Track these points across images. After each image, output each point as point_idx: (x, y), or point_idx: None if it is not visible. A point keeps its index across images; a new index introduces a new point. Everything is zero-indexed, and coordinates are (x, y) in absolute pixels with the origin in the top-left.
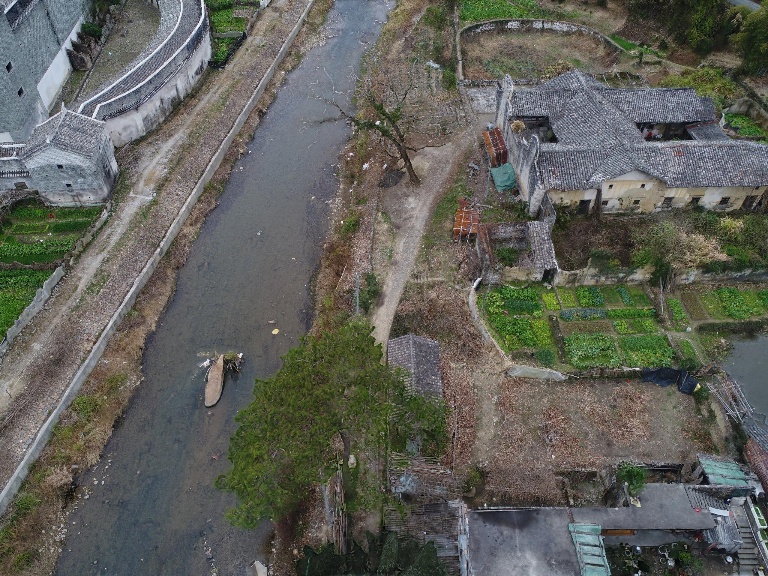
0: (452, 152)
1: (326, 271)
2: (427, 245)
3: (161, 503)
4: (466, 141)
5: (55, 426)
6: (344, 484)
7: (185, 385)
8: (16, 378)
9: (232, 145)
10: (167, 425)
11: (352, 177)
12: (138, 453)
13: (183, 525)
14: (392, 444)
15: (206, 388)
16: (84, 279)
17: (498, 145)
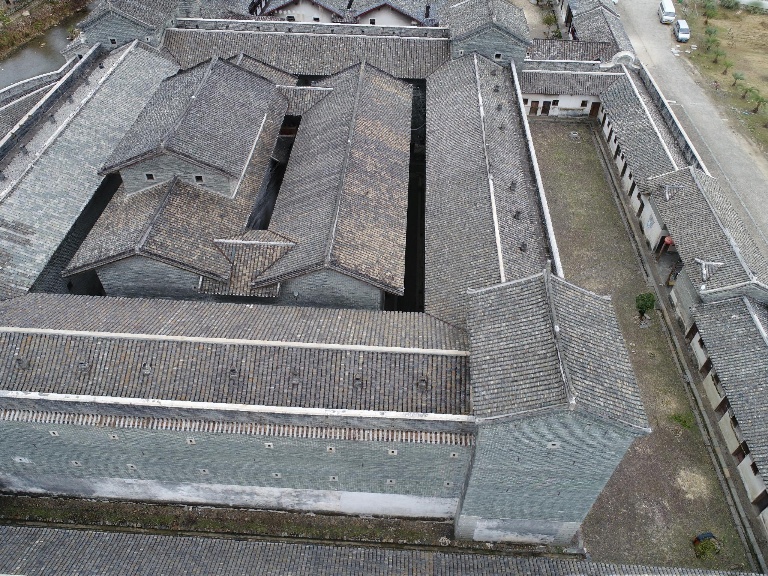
0: None
1: None
2: None
3: None
4: None
5: None
6: None
7: None
8: None
9: None
10: None
11: None
12: None
13: None
14: None
15: None
16: None
17: None
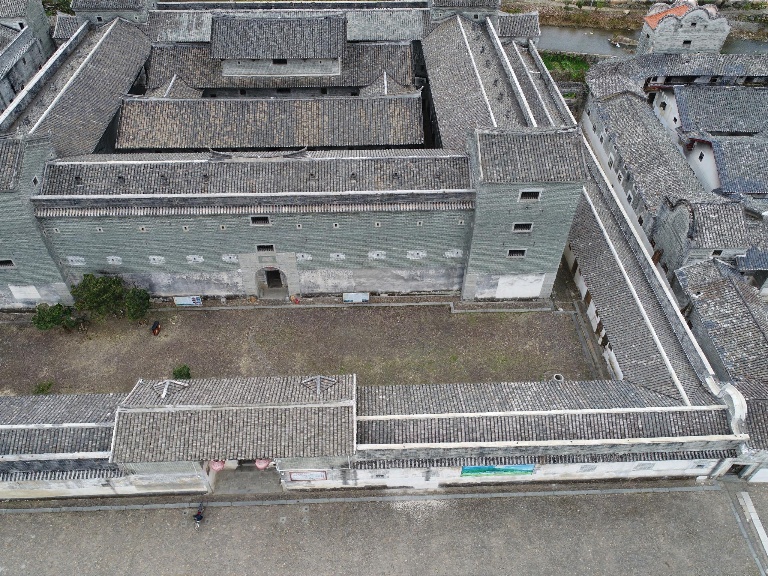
0: None
1: None
2: None
3: None
4: None
5: None
6: None
7: None
8: None
9: None
10: None
11: None
12: None
13: None
14: (649, 5)
15: (635, 41)
16: None
17: None
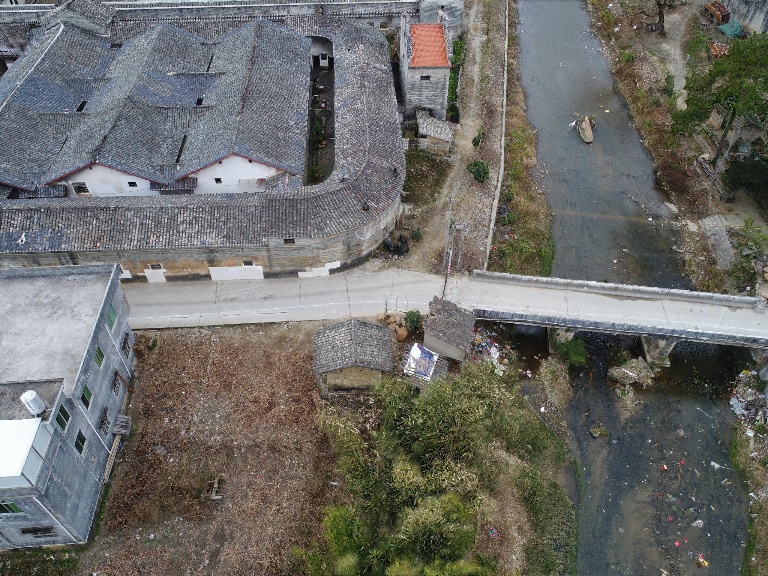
0: (681, 19)
1: (625, 81)
2: (691, 67)
3: (589, 181)
4: (689, 12)
5: (506, 144)
6: (713, 161)
7: (564, 134)
8: (472, 118)
9: (509, 17)
10: (567, 150)
11: (609, 36)
12: (558, 161)
13: (609, 189)
14: None
15: (585, 132)
16: (475, 76)
17: (722, 10)
